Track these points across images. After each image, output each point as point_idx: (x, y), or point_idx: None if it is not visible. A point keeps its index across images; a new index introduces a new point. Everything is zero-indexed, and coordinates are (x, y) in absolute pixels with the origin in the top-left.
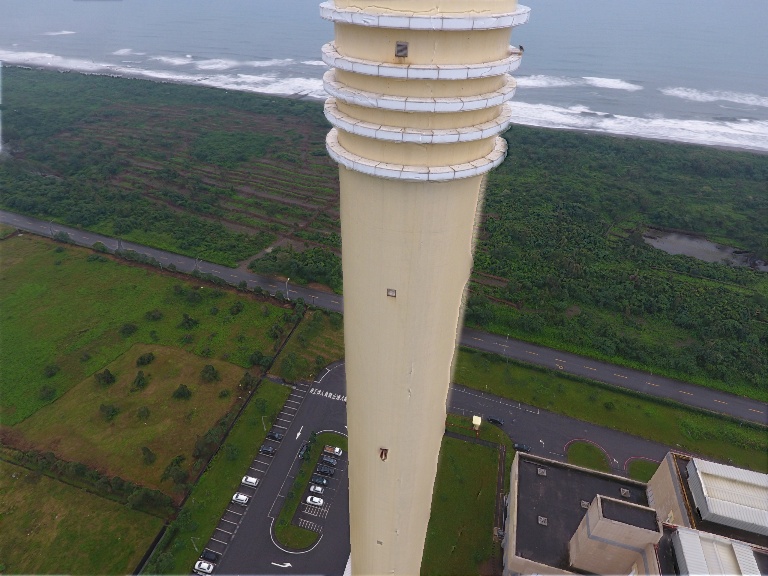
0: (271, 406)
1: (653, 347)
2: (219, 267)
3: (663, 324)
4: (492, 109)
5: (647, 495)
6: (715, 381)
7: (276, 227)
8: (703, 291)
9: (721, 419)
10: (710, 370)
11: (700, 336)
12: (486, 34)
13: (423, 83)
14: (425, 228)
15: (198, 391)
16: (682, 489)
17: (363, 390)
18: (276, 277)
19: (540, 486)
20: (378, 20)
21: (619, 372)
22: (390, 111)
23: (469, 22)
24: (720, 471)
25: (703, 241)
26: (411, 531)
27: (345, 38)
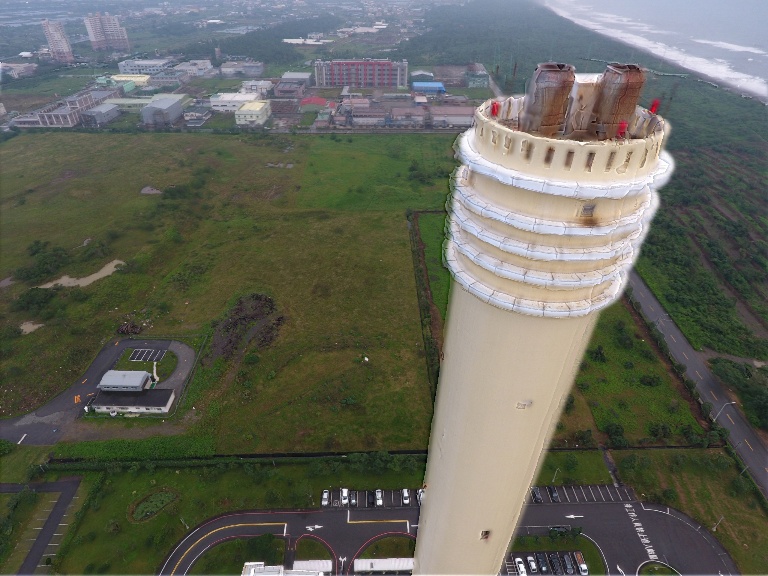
0: (579, 473)
1: None
2: (681, 337)
3: None
4: (518, 257)
5: None
6: None
7: None
8: None
9: None
10: None
11: None
12: (515, 189)
13: None
14: (460, 320)
15: None
16: None
17: None
18: (729, 392)
19: None
20: None
21: None
22: None
23: (496, 173)
24: None
25: None
26: None
27: None
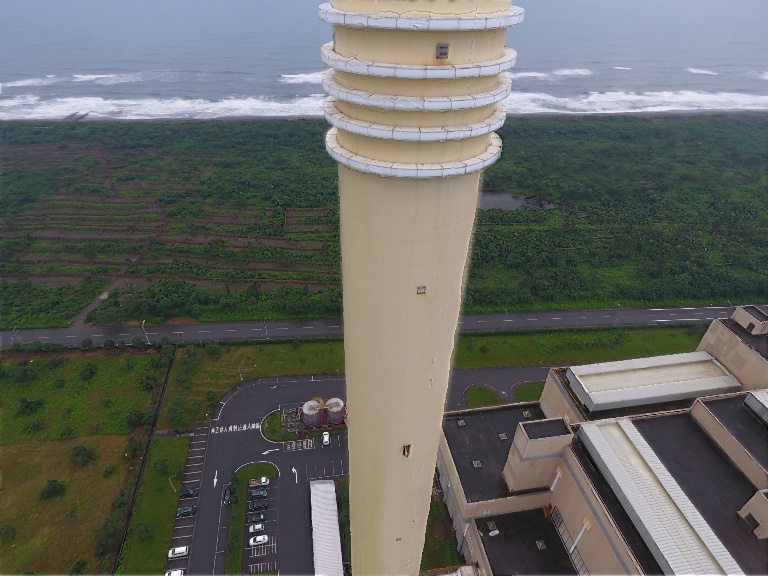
0: (172, 463)
1: (498, 290)
2: (46, 331)
3: (499, 269)
4: None
5: (542, 410)
6: (548, 304)
7: (103, 269)
8: (518, 235)
9: (562, 332)
10: (542, 296)
11: (527, 271)
12: None
13: (466, 82)
14: (453, 220)
15: (73, 481)
16: (569, 394)
17: (385, 395)
18: (125, 323)
19: (464, 436)
20: (428, 24)
21: (481, 318)
22: (434, 112)
23: (498, 21)
24: (589, 370)
25: (503, 194)
26: (424, 515)
27: (376, 44)
